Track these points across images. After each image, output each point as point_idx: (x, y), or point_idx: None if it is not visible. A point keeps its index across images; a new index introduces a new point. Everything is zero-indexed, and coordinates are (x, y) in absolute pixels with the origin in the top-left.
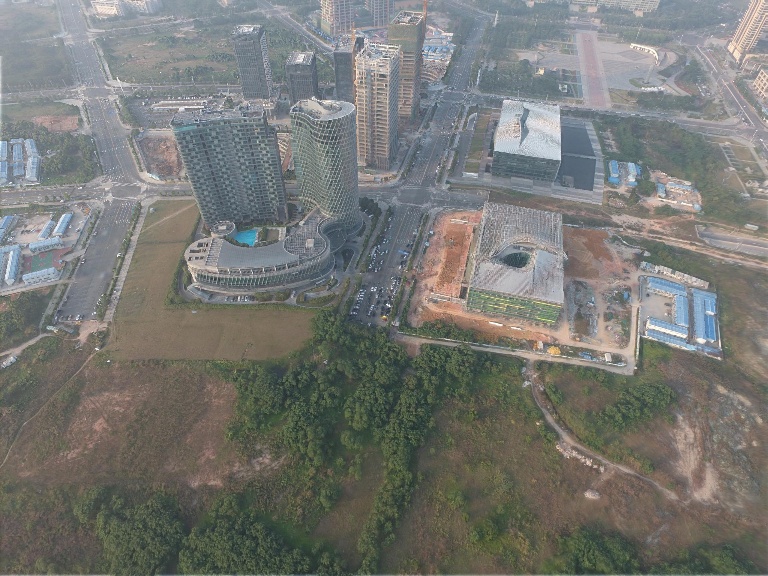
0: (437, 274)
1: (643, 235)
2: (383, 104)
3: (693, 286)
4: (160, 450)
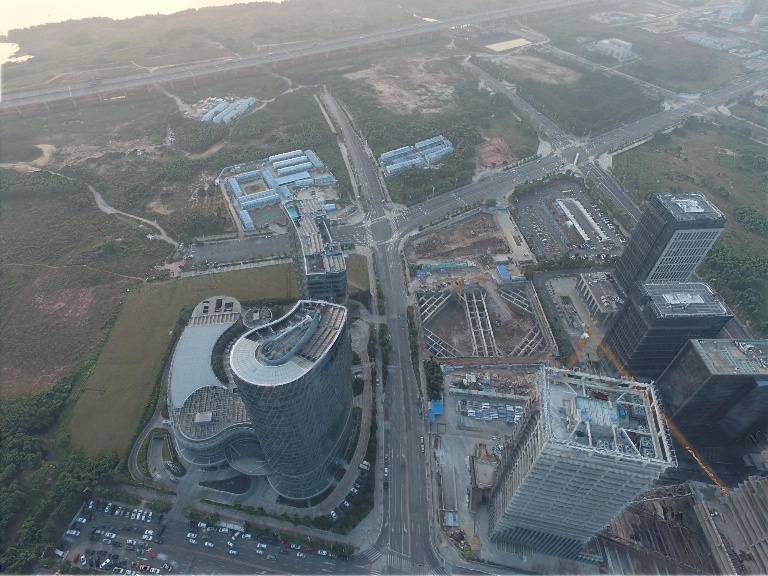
0: None
1: None
2: None
3: None
4: (5, 351)
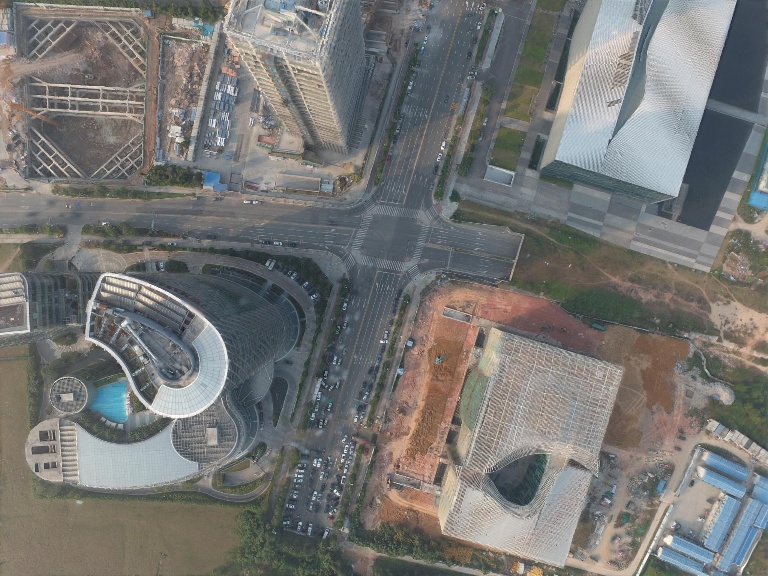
0: (408, 434)
1: (743, 355)
2: None
3: (763, 468)
4: None
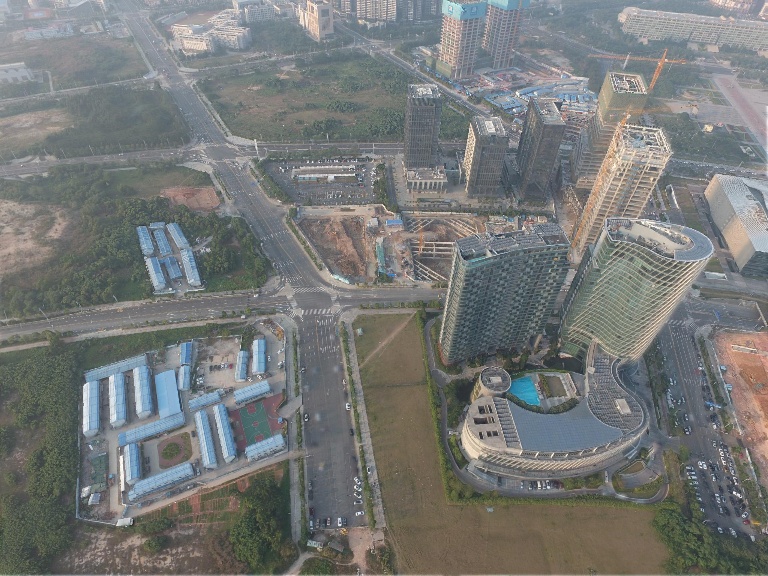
0: (767, 438)
1: None
2: (640, 199)
3: None
4: None
